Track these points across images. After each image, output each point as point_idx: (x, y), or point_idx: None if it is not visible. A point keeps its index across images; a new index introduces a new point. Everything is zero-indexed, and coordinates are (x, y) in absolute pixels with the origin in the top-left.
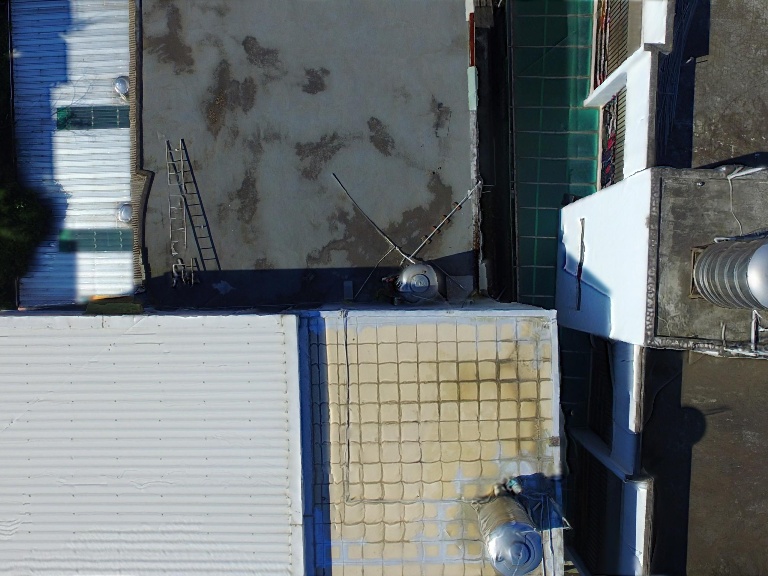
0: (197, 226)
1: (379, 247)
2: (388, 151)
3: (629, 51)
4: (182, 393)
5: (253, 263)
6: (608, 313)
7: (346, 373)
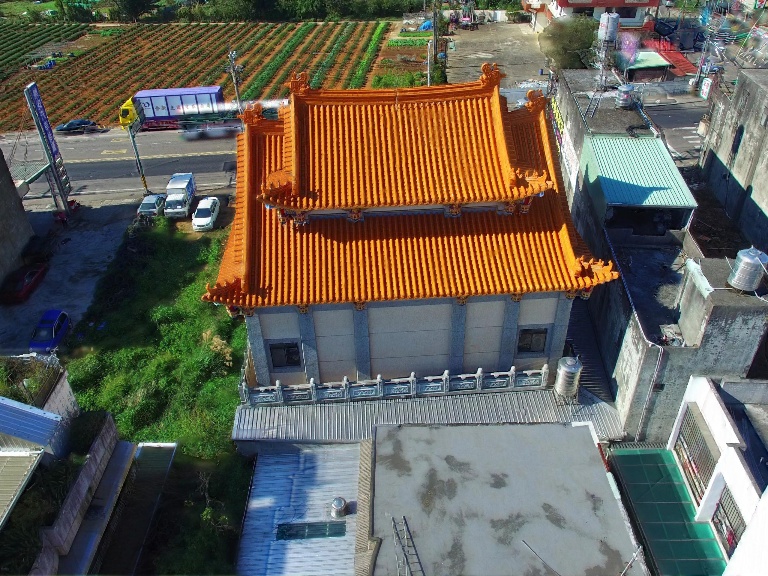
0: None
1: None
2: (562, 525)
3: (717, 461)
4: None
5: None
6: None
7: None
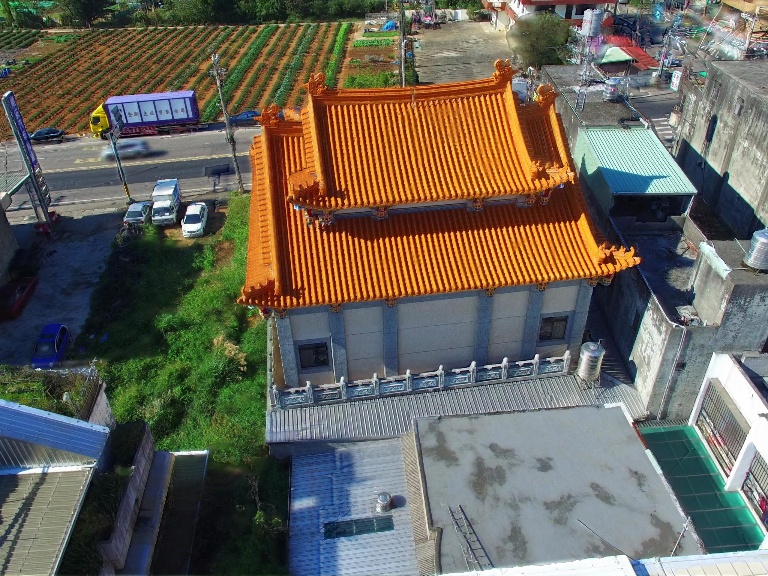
0: (483, 564)
1: None
2: (612, 503)
3: (746, 432)
4: None
5: None
6: None
7: None
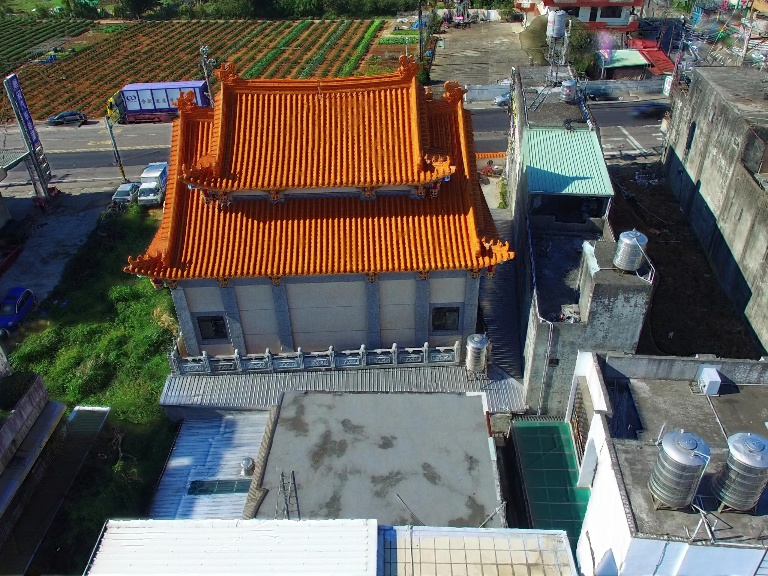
0: None
1: None
2: (436, 482)
3: None
4: (286, 570)
5: None
6: (613, 561)
7: (411, 569)
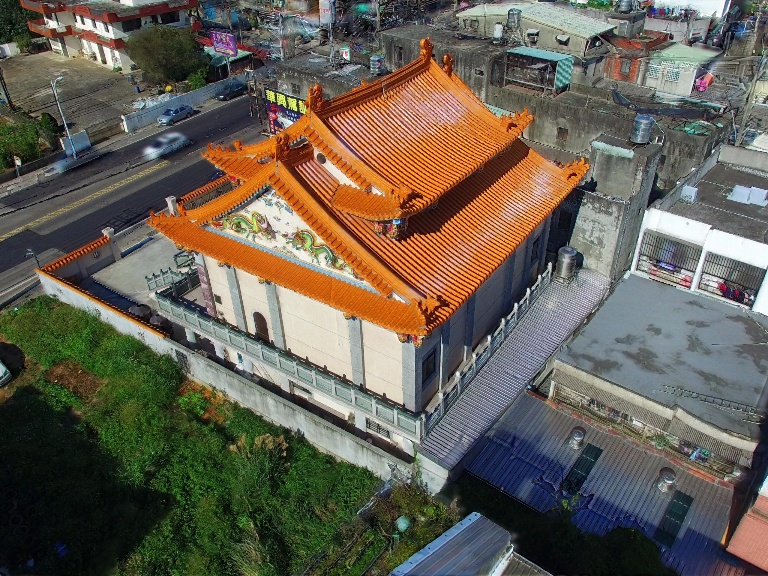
0: None
1: (765, 348)
2: (708, 325)
3: (697, 248)
4: None
5: (756, 394)
6: None
7: None
